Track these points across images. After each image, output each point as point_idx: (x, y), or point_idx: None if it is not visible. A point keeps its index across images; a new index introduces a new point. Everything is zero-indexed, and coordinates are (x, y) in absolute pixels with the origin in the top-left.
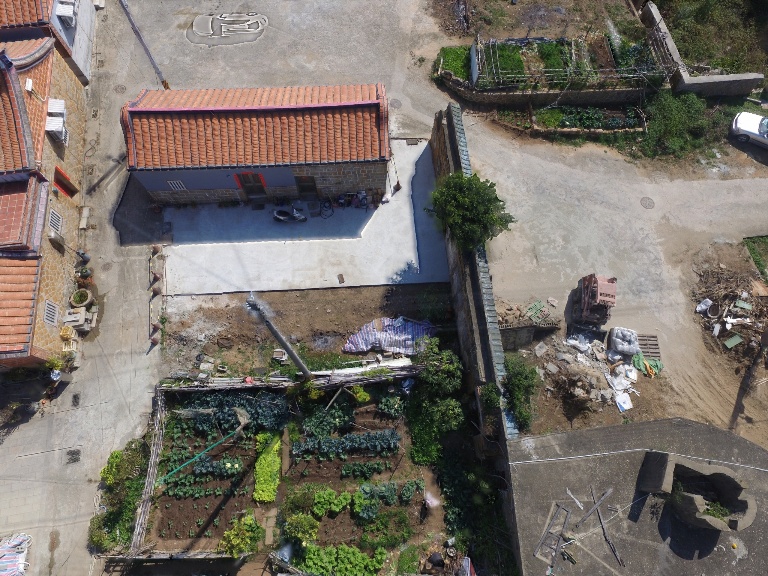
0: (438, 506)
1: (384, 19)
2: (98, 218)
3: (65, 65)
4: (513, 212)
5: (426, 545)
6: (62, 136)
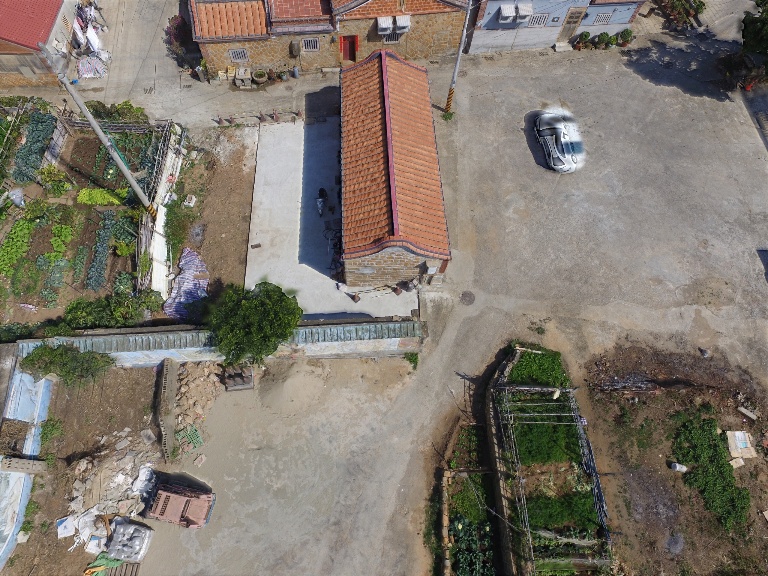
0: (30, 319)
1: (598, 288)
2: (332, 78)
3: (460, 26)
4: (322, 428)
5: (3, 307)
6: (381, 32)
